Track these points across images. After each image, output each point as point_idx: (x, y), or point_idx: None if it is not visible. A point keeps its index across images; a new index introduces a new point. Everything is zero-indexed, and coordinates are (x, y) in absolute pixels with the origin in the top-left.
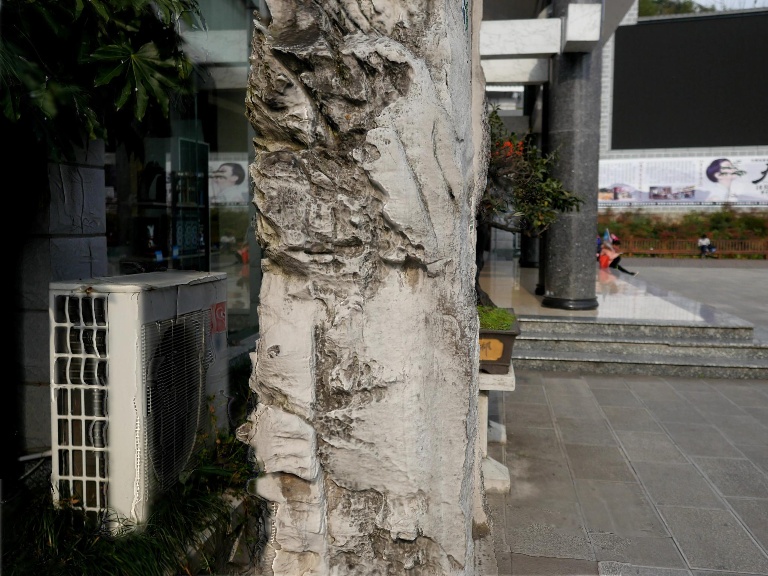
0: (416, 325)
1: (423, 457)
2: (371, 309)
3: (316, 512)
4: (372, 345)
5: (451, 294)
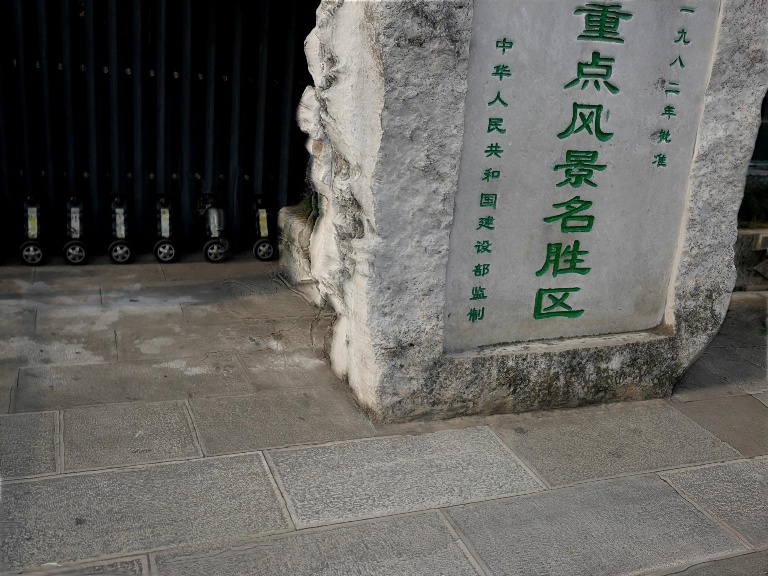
0: (354, 30)
1: (356, 137)
2: (338, 16)
3: (323, 167)
4: (336, 44)
5: (371, 5)
